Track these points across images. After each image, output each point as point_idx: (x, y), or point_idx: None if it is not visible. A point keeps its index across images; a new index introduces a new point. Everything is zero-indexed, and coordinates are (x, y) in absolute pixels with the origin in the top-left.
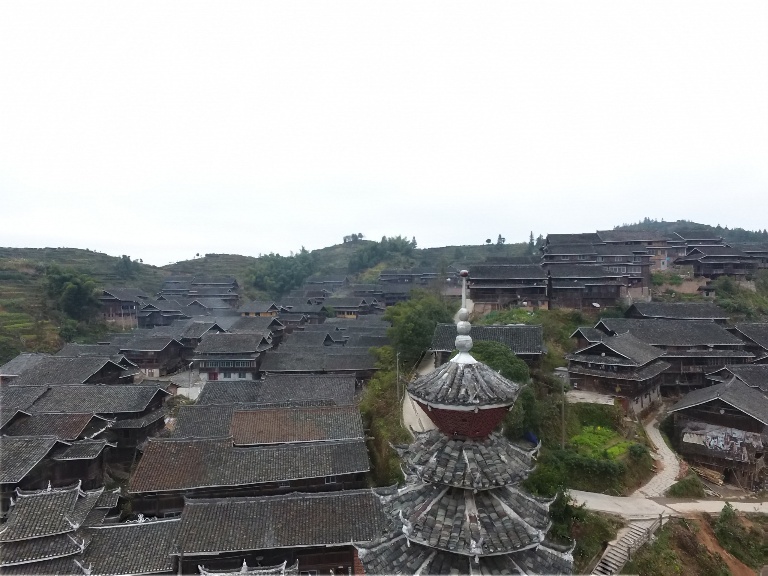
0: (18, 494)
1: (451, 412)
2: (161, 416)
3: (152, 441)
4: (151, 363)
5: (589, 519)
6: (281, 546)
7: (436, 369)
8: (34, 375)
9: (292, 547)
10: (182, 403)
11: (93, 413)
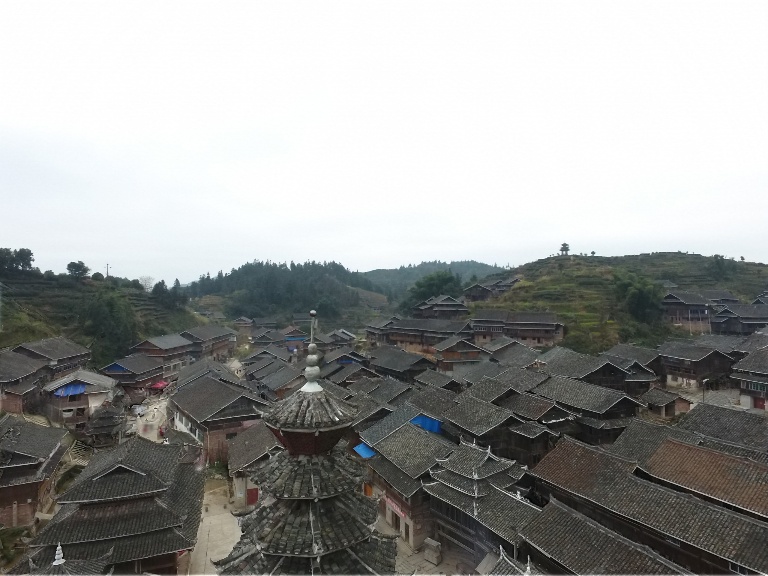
0: (461, 441)
1: None
2: None
3: (567, 439)
4: (688, 373)
5: None
6: None
7: None
8: (555, 365)
9: None
10: None
11: (554, 403)
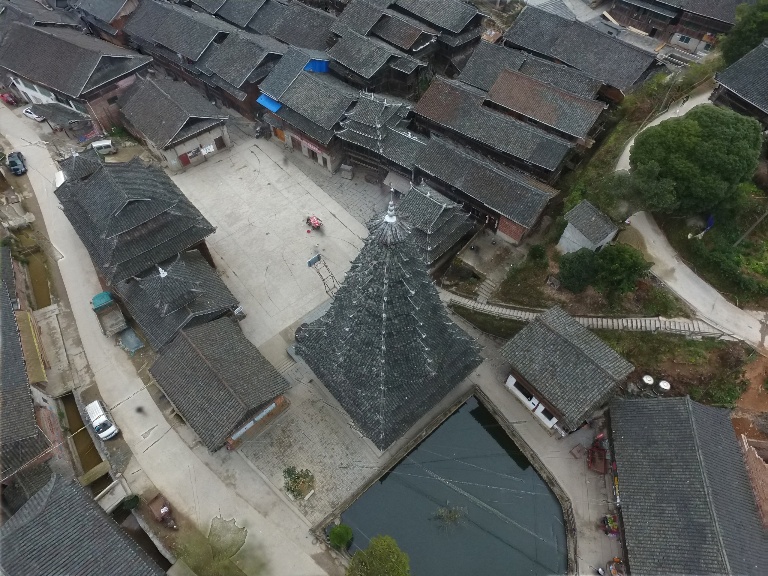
0: (360, 94)
1: None
2: (476, 36)
3: (438, 78)
4: None
5: (663, 297)
6: (463, 190)
7: (383, 214)
8: None
9: (468, 194)
10: (517, 10)
11: (422, 30)
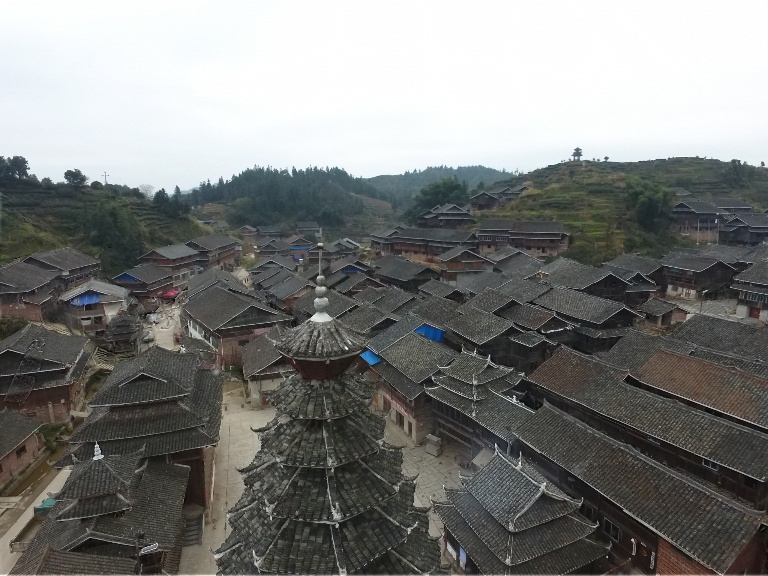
0: (462, 350)
1: None
2: None
3: (564, 348)
4: (689, 283)
5: None
6: (584, 480)
7: None
8: (558, 276)
9: (593, 488)
10: None
11: (554, 314)
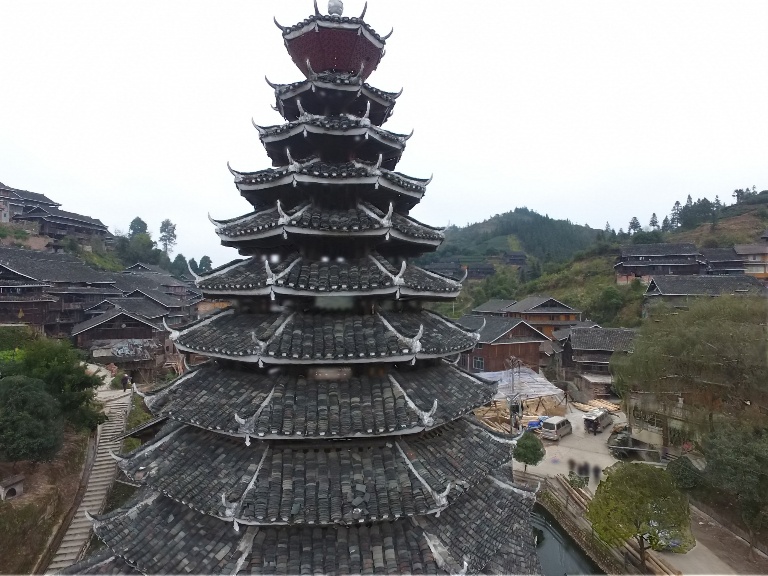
0: None
1: (368, 44)
2: None
3: None
4: None
5: None
6: None
7: None
8: None
9: None
10: None
11: None
